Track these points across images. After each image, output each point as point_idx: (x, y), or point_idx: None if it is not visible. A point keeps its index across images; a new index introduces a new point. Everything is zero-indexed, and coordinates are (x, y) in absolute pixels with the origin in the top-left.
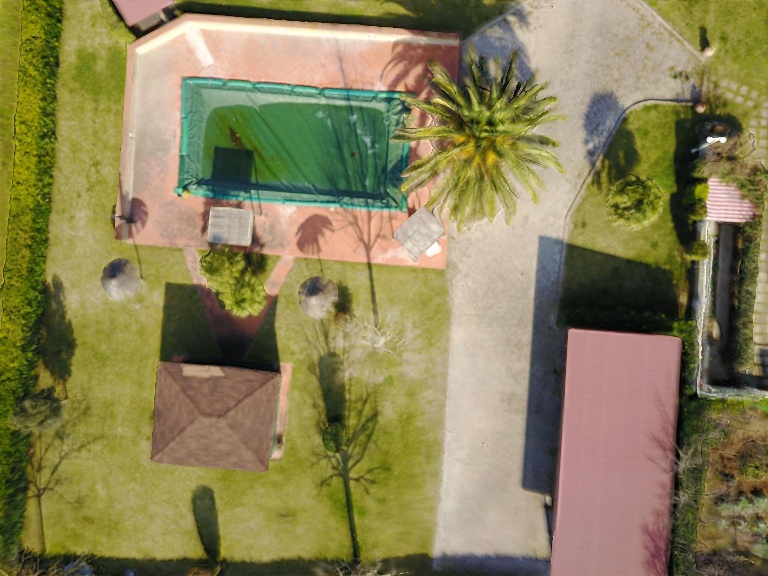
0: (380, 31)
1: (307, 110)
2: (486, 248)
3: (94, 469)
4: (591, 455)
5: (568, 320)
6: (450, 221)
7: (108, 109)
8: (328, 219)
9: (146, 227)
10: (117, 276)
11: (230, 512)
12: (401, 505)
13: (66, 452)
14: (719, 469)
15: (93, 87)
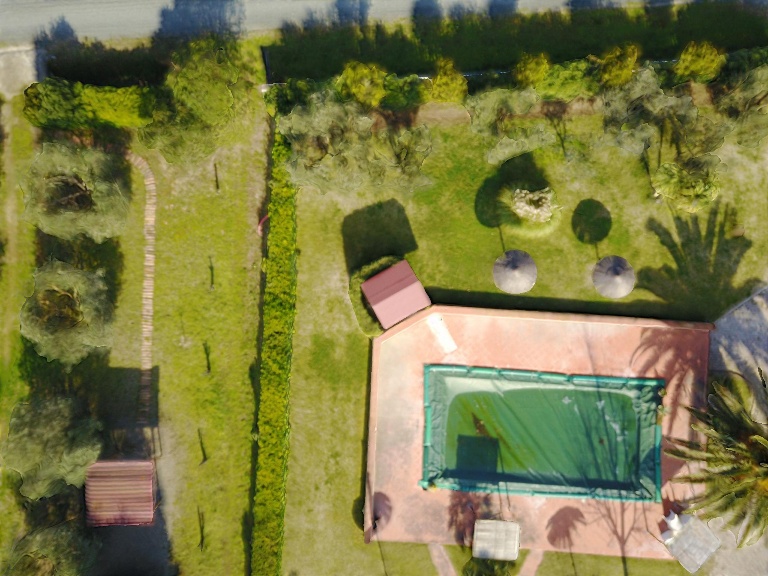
0: (635, 322)
1: (553, 395)
2: None
3: None
4: None
5: None
6: None
7: (348, 398)
8: (579, 511)
9: (390, 523)
10: None
11: None
12: None
13: None
14: None
15: (332, 375)
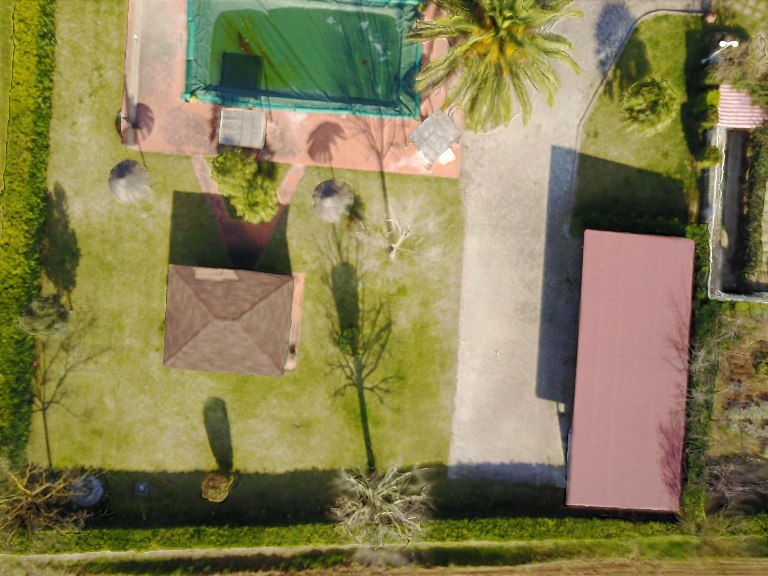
0: None
1: (318, 15)
2: (499, 157)
3: (101, 382)
4: (606, 354)
5: (583, 224)
6: (463, 129)
7: (111, 11)
8: (340, 127)
9: (152, 134)
10: (126, 176)
11: (242, 423)
12: (415, 414)
13: (71, 365)
14: (726, 374)
15: None
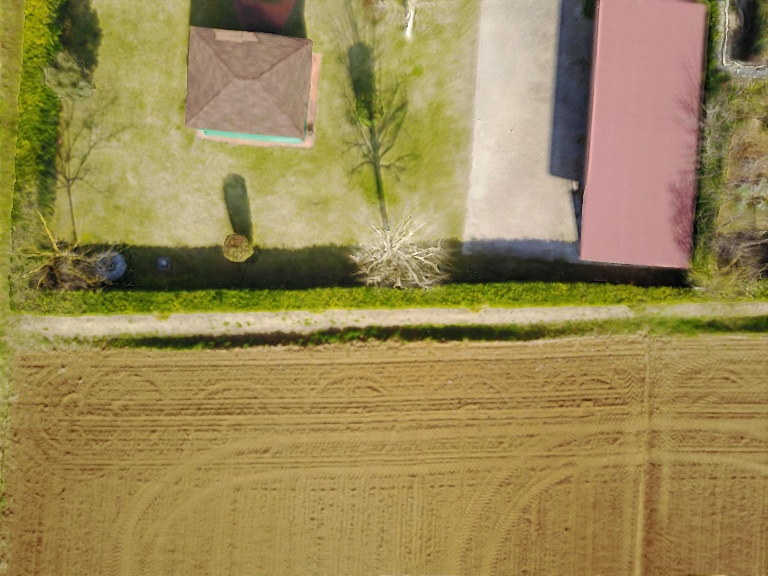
0: None
1: None
2: None
3: (124, 158)
4: (622, 112)
5: None
6: None
7: None
8: None
9: None
10: None
11: (262, 200)
12: (431, 191)
13: (95, 142)
14: (740, 152)
15: None
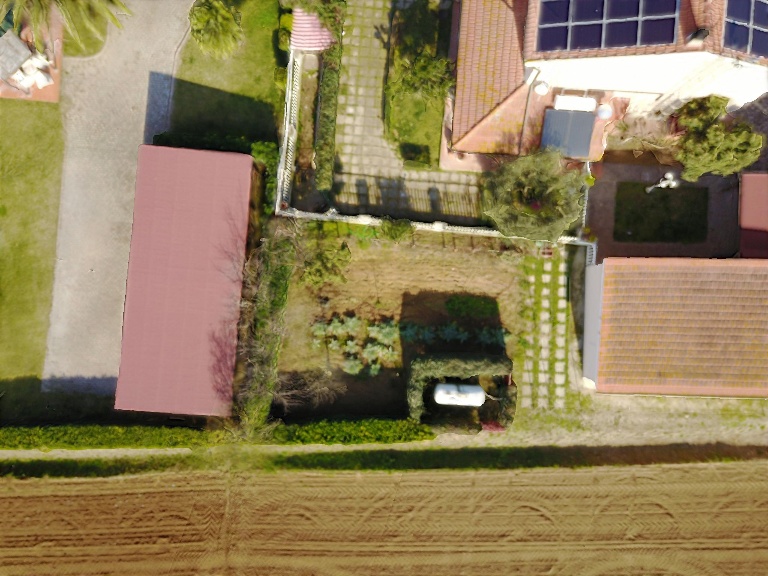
0: None
1: None
2: (99, 82)
3: None
4: (159, 264)
5: (154, 142)
6: (62, 55)
7: None
8: None
9: None
10: None
11: None
12: (12, 329)
13: None
14: (315, 292)
15: None
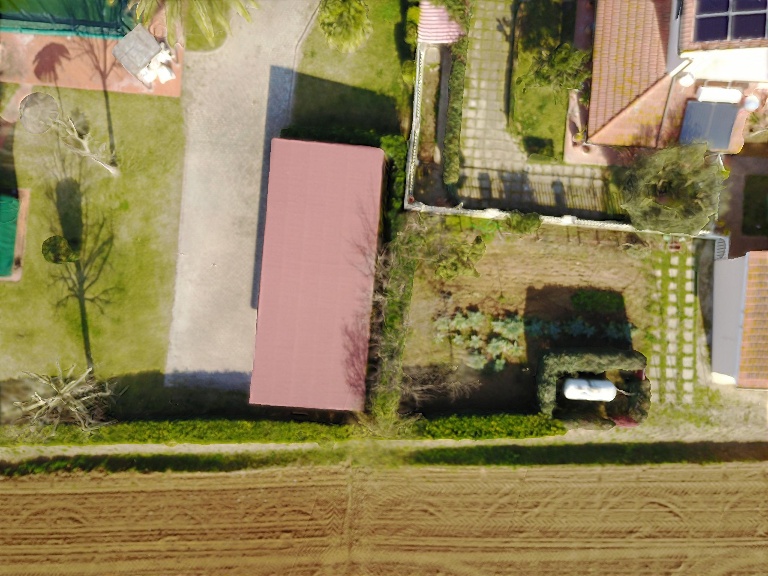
0: None
1: None
2: (220, 77)
3: None
4: (292, 258)
5: (282, 136)
6: (184, 50)
7: None
8: (65, 48)
9: None
10: None
11: None
12: (135, 324)
13: None
14: (437, 286)
15: None
